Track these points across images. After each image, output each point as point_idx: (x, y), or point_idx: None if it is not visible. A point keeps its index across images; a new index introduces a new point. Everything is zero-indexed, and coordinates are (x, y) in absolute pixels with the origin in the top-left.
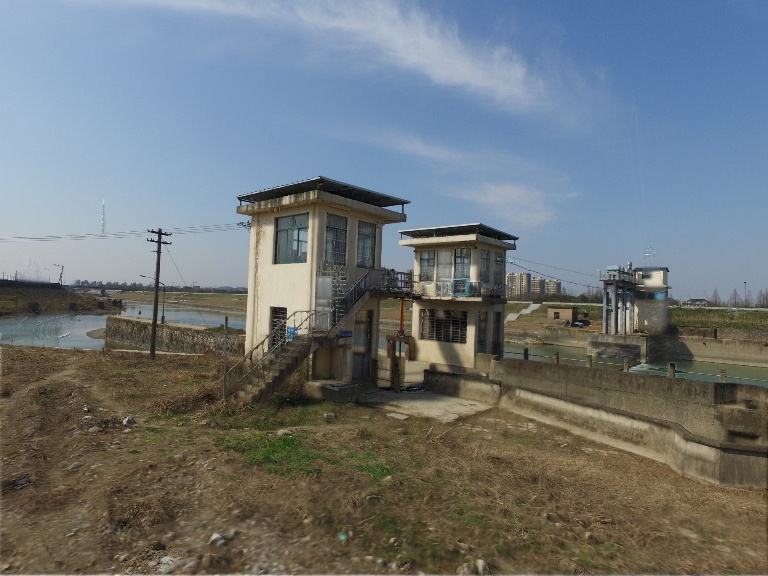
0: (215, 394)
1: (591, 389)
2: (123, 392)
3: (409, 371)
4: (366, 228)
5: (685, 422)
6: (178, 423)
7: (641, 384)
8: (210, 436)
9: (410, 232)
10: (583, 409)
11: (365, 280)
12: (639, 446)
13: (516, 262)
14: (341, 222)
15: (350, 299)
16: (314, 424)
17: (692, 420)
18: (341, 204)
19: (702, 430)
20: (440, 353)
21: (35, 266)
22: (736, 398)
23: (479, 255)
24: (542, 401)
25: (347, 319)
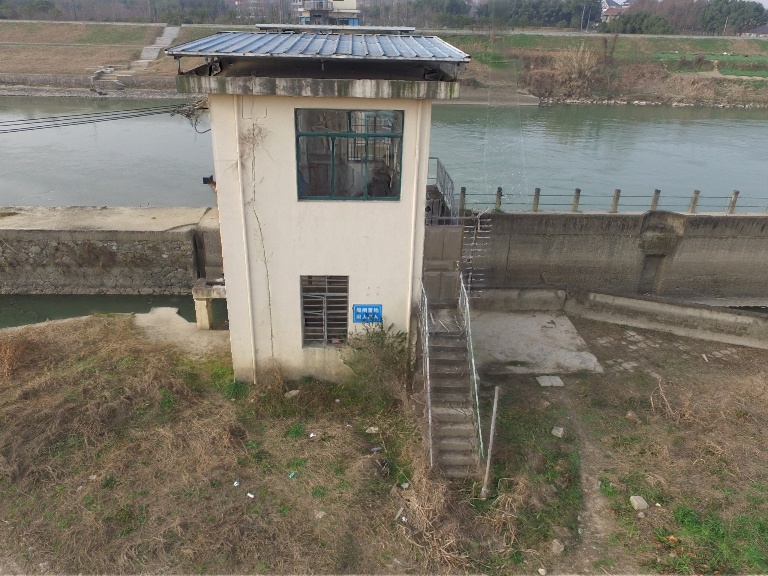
0: None
1: (536, 237)
2: (317, 569)
3: None
4: None
5: (616, 254)
6: (534, 571)
7: (584, 225)
8: (627, 567)
9: (276, 27)
10: (683, 310)
11: None
12: (743, 337)
13: None
14: None
15: None
16: (578, 457)
17: (622, 251)
18: None
19: (628, 258)
20: None
21: None
22: (650, 224)
23: None
24: (629, 304)
25: None
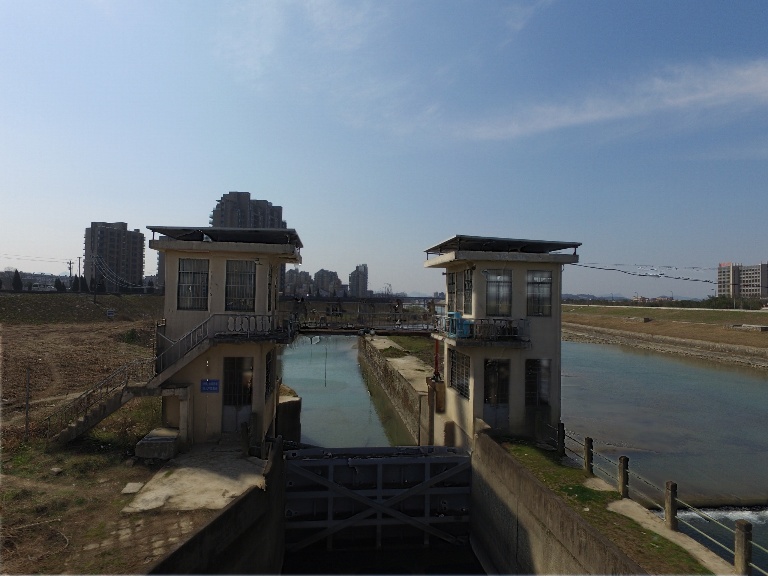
0: (47, 429)
1: (535, 523)
2: (34, 415)
3: (435, 426)
4: (240, 267)
5: None
6: None
7: (582, 545)
8: None
9: (433, 251)
10: None
11: (205, 327)
12: None
13: (669, 274)
14: (201, 265)
15: (182, 348)
16: (24, 476)
17: None
18: (184, 249)
19: None
20: (456, 410)
21: (303, 292)
22: None
23: (481, 278)
24: None
25: (175, 369)
